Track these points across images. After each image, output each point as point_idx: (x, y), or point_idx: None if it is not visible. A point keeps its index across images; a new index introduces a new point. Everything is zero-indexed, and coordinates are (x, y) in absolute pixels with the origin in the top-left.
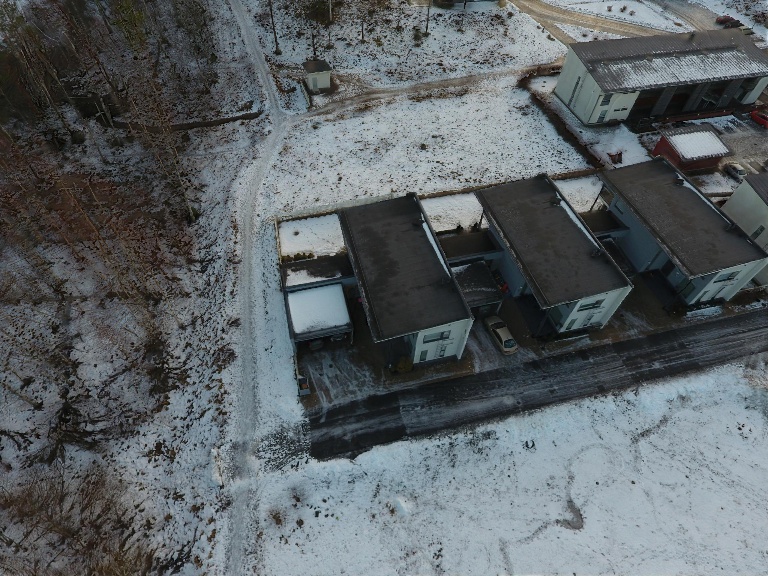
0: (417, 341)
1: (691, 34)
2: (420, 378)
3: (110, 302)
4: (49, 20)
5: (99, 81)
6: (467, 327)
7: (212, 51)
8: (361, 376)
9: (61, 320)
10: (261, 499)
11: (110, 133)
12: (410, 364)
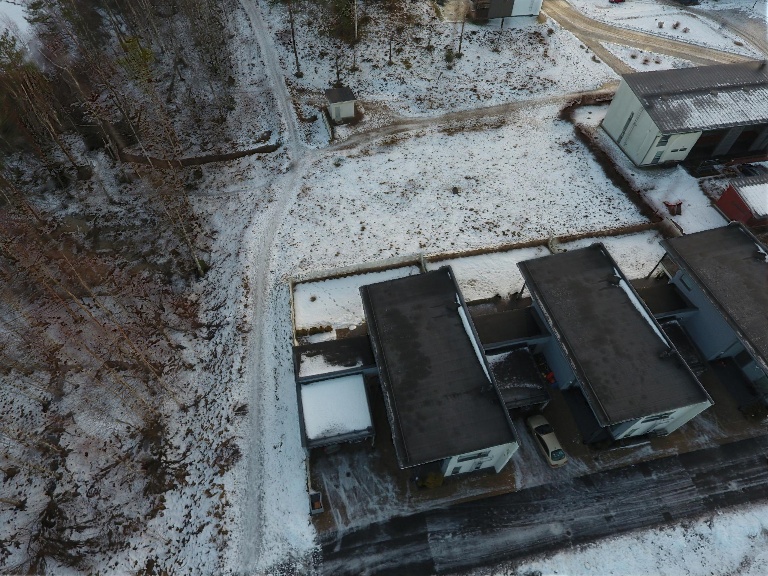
0: (450, 461)
1: (762, 63)
2: (451, 495)
3: (107, 374)
4: (57, 46)
5: (111, 106)
6: (511, 449)
7: (230, 73)
8: (383, 490)
9: (53, 395)
10: None
11: (119, 167)
12: (440, 480)
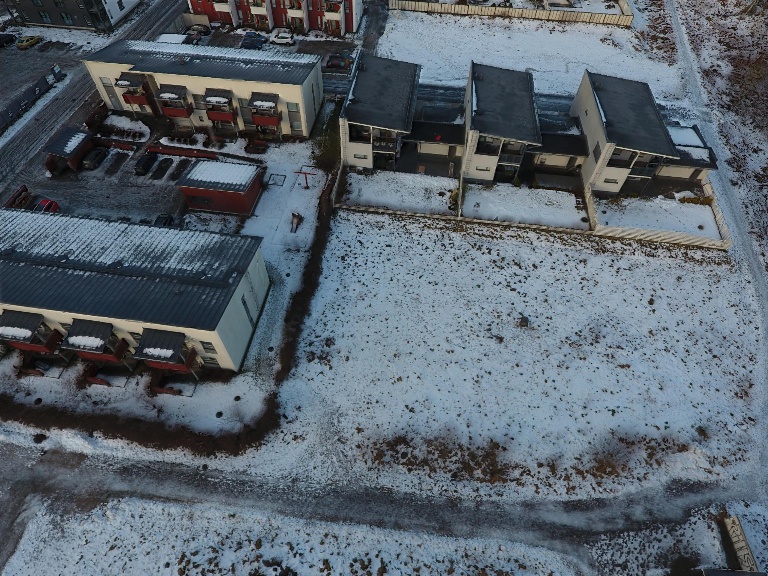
0: None
1: None
2: None
3: None
4: None
5: None
6: None
7: None
8: None
9: None
10: (689, 103)
11: None
12: None
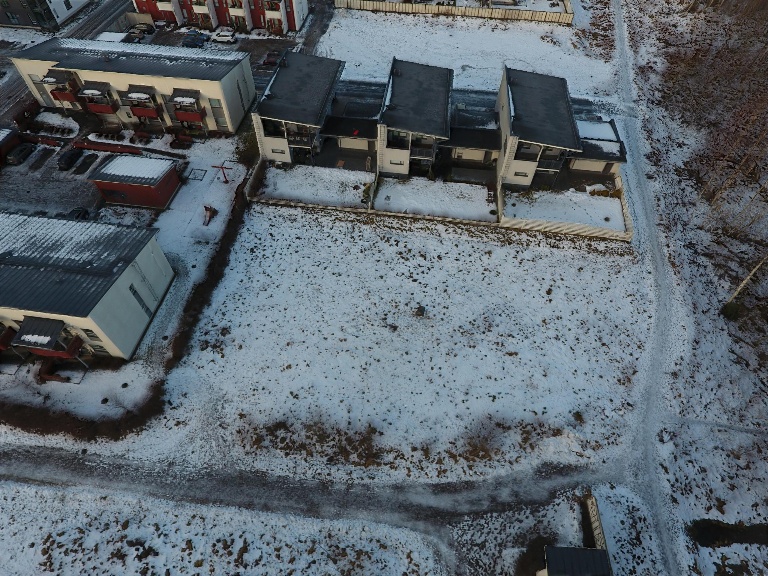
0: None
1: None
2: None
3: None
4: None
5: None
6: None
7: None
8: None
9: None
10: None
11: None
12: None
